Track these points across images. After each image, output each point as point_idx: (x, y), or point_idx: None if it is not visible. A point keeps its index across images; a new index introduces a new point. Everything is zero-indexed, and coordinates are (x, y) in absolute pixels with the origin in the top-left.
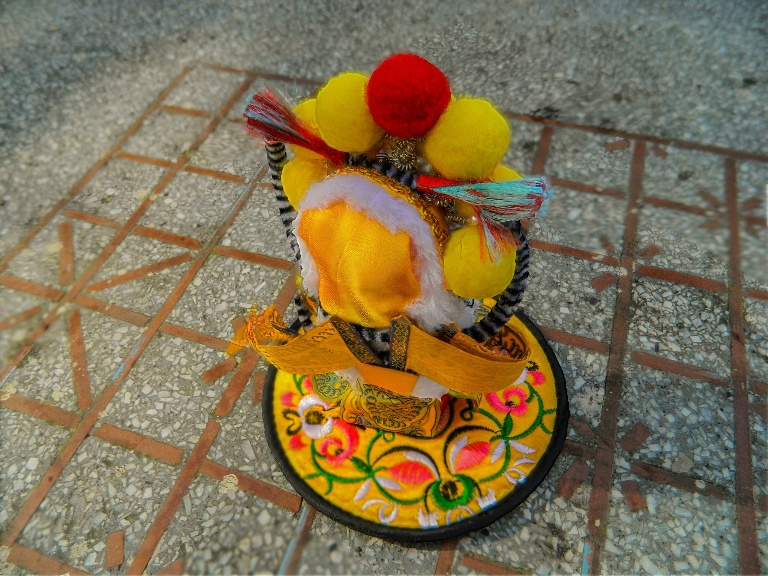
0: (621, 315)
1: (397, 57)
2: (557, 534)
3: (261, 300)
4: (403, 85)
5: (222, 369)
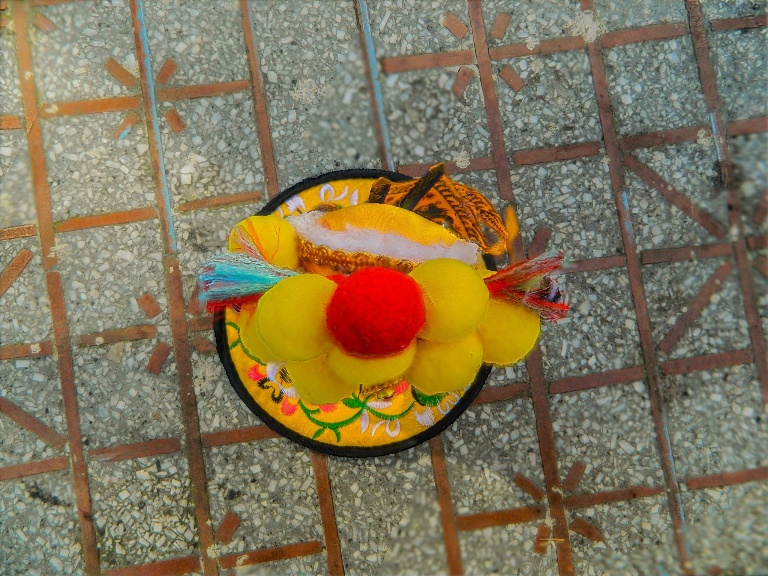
0: (200, 490)
1: (397, 319)
2: (199, 246)
3: (553, 334)
4: (371, 283)
5: (537, 247)
